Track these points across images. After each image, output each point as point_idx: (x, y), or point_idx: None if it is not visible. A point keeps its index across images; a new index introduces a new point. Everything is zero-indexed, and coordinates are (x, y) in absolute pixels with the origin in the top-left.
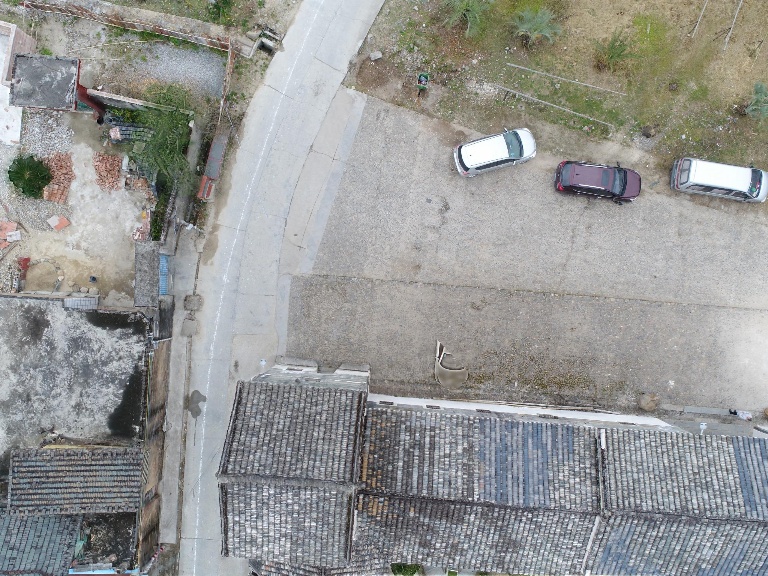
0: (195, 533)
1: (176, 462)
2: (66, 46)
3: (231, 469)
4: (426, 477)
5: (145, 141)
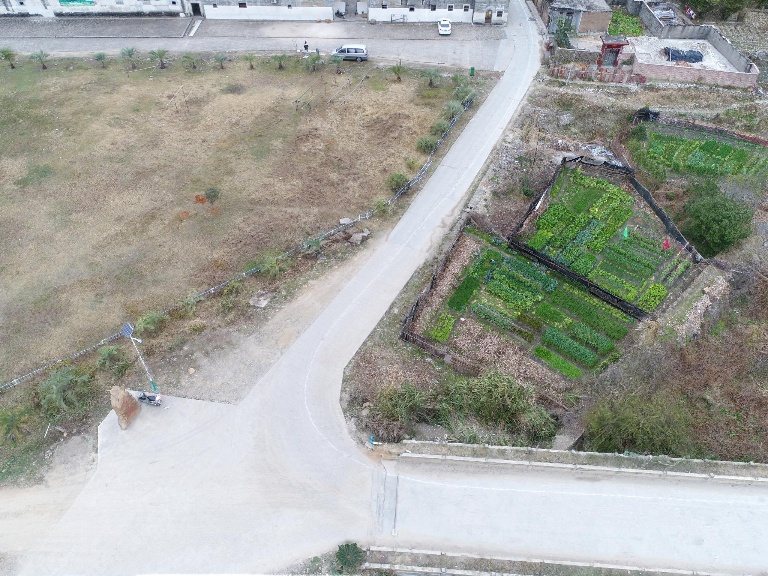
0: (521, 2)
1: (533, 11)
2: None
3: None
4: None
5: None
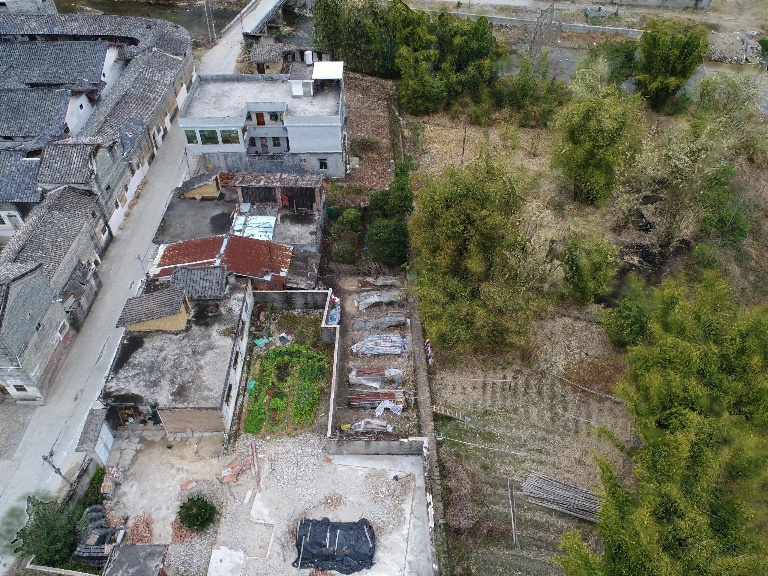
0: None
1: None
2: None
3: (3, 287)
4: None
5: None
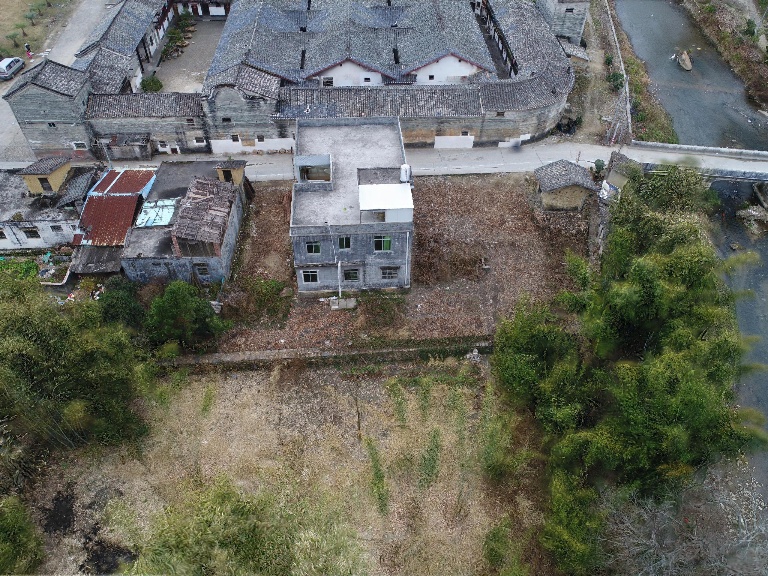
0: None
1: None
2: None
3: None
4: None
5: None
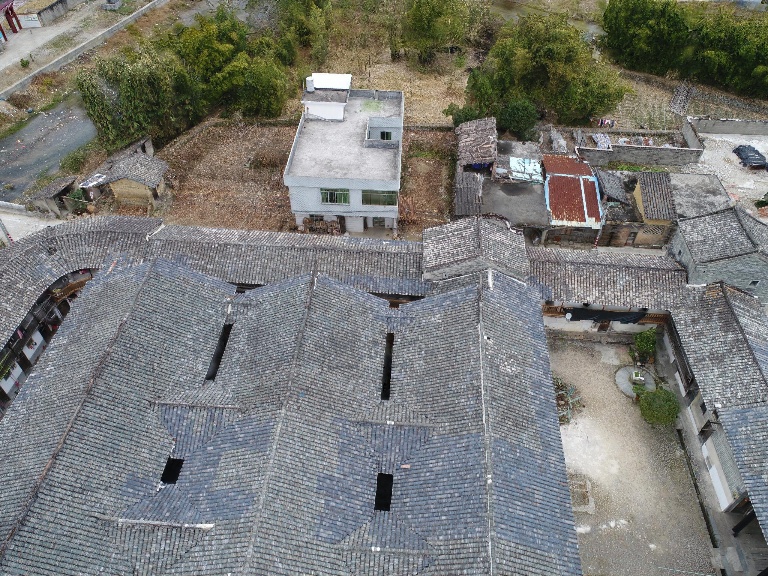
0: None
1: None
2: None
3: None
4: (743, 315)
5: None
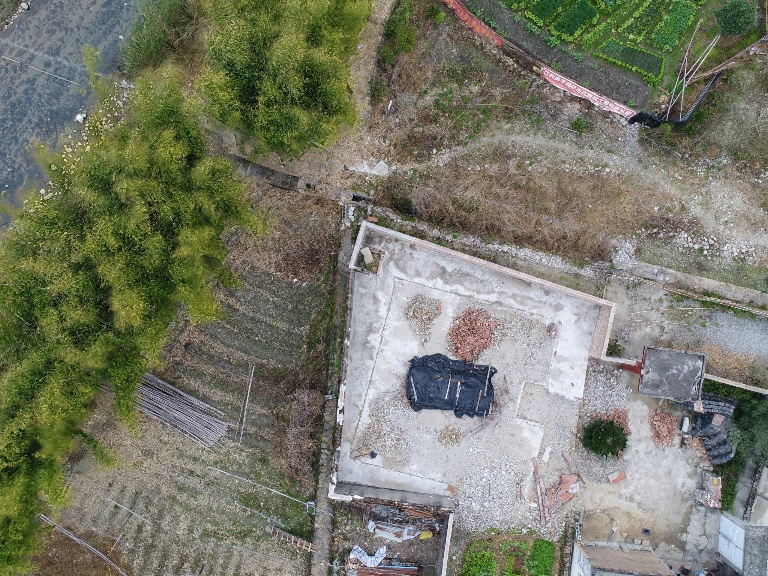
0: None
1: None
2: (628, 308)
3: None
4: None
5: (724, 414)
